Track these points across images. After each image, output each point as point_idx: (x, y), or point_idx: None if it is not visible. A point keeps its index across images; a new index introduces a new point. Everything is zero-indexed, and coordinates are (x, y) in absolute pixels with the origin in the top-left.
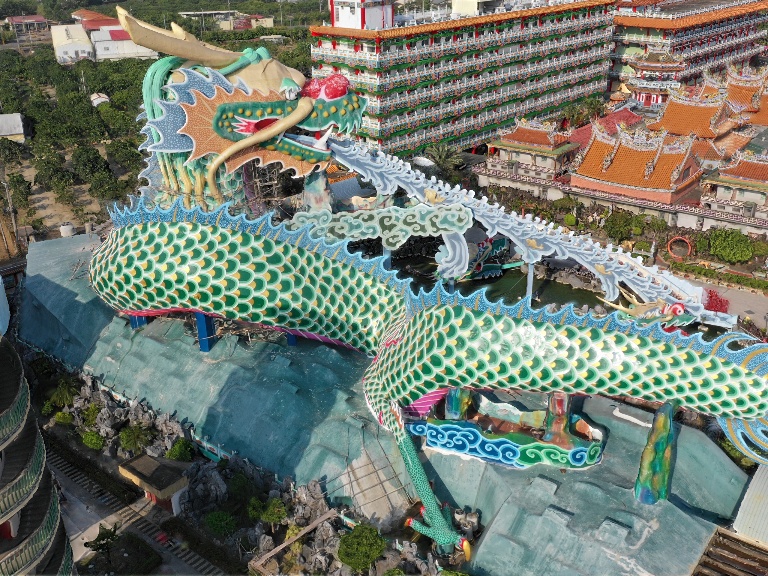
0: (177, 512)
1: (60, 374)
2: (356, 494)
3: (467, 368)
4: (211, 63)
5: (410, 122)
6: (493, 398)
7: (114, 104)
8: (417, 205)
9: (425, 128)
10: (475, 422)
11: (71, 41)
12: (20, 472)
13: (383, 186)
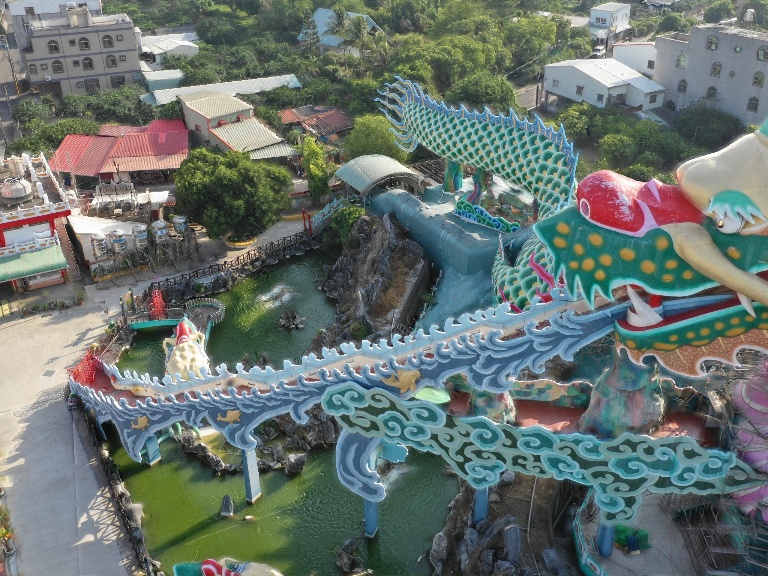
0: None
1: None
2: None
3: None
4: None
5: None
6: None
7: None
8: None
9: None
10: None
11: None
12: None
13: None
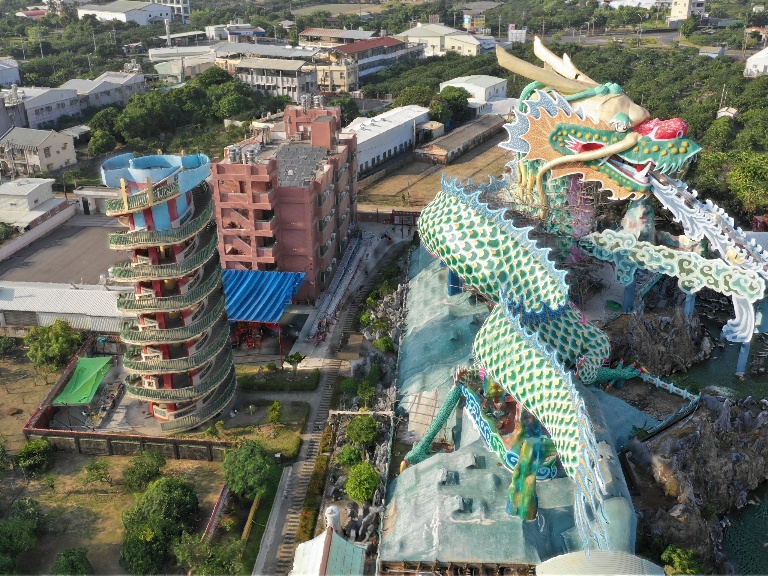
0: (352, 375)
1: (397, 279)
2: (411, 411)
3: (479, 353)
4: (561, 89)
5: None
6: None
7: (736, 120)
8: (716, 259)
9: None
10: (497, 406)
11: (765, 56)
12: (176, 262)
13: (691, 231)
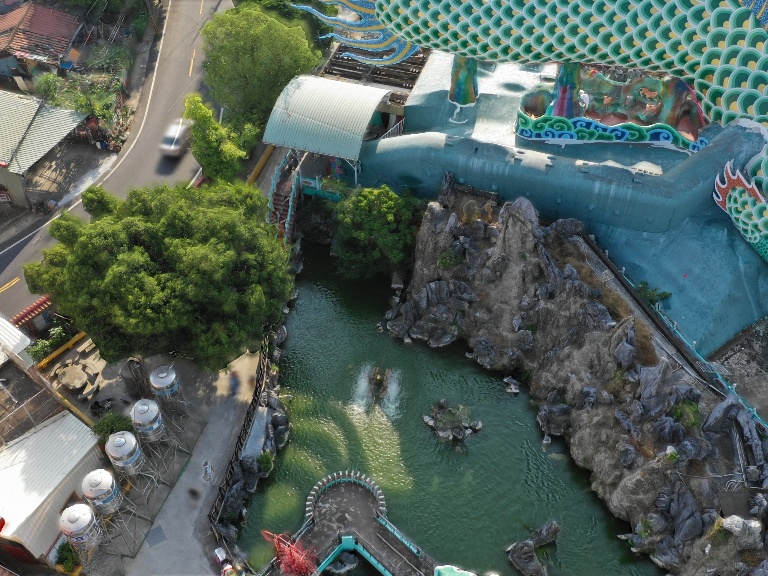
0: None
1: None
2: None
3: None
4: None
5: None
6: (657, 160)
7: None
8: None
9: None
10: None
11: None
12: None
13: None
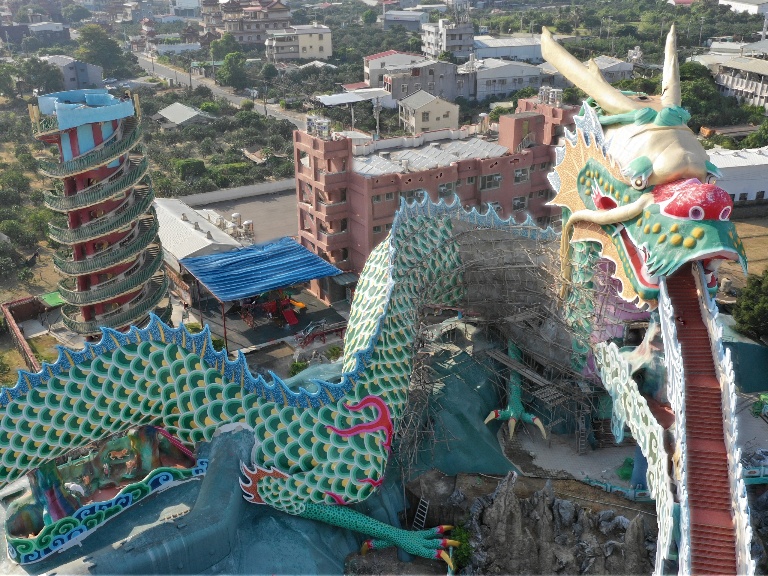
0: None
1: None
2: None
3: None
4: None
5: None
6: (174, 501)
7: None
8: None
9: None
10: None
11: None
12: None
13: None
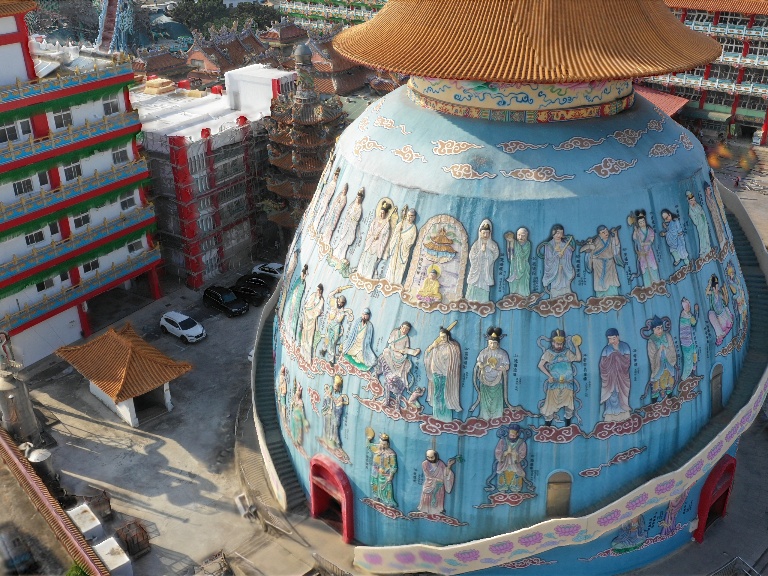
0: None
1: None
2: None
3: None
4: None
5: (304, 10)
6: None
7: None
8: None
9: (328, 21)
10: None
11: None
12: None
13: None
